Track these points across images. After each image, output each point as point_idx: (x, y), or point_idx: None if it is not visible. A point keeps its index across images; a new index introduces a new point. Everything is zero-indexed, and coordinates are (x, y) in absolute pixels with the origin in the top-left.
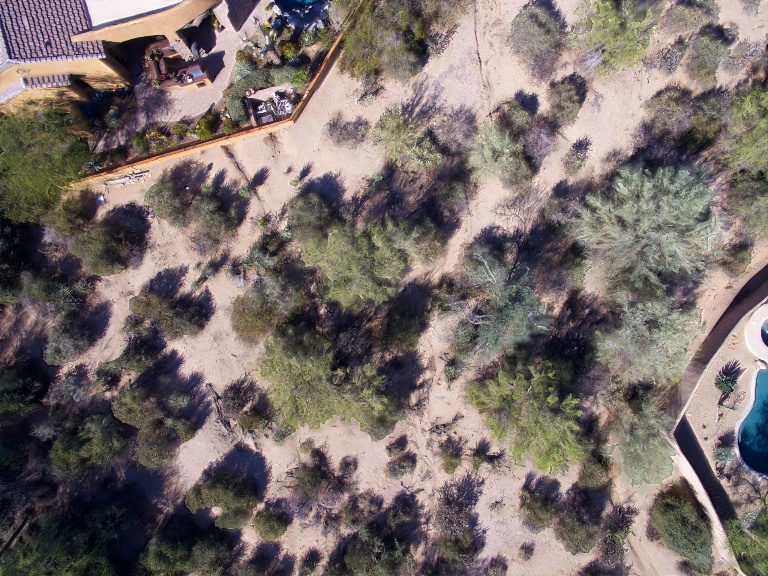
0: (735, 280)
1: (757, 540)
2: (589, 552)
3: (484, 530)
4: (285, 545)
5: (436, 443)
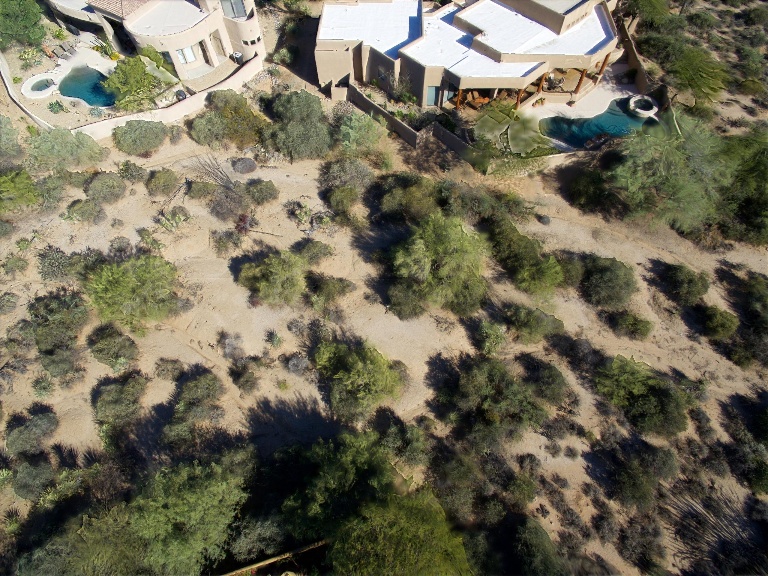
0: (6, 103)
1: (170, 105)
2: (138, 188)
3: (88, 250)
4: (18, 410)
5: (5, 277)
